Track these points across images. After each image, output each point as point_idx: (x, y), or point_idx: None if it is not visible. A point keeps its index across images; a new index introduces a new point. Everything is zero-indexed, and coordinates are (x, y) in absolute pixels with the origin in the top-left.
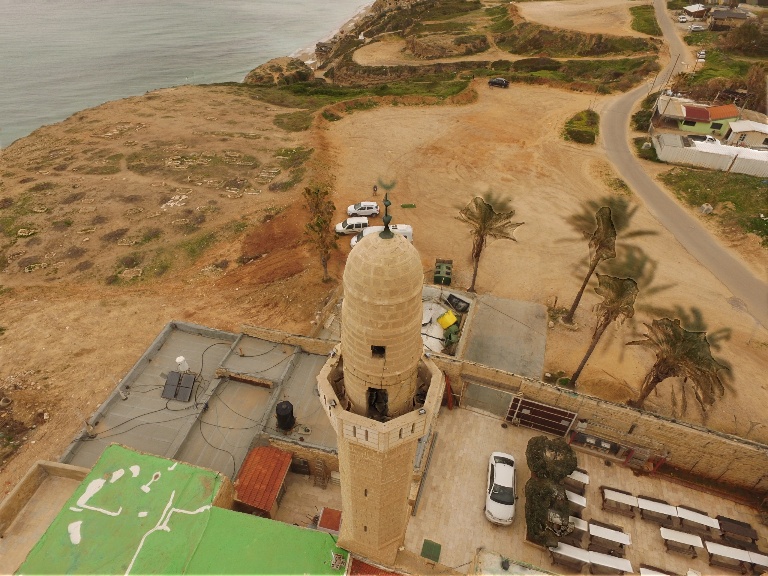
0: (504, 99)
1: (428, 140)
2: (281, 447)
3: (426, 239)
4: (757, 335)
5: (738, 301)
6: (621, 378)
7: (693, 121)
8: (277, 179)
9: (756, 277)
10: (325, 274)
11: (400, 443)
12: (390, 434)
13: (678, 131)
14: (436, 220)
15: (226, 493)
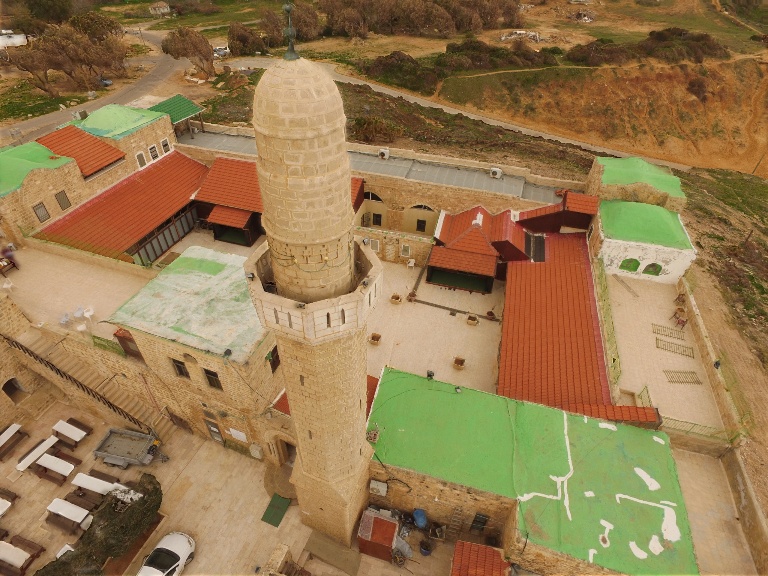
0: None
1: None
2: None
3: None
4: None
5: None
6: None
7: None
8: None
9: None
10: None
11: None
12: None
13: None
14: None
15: None
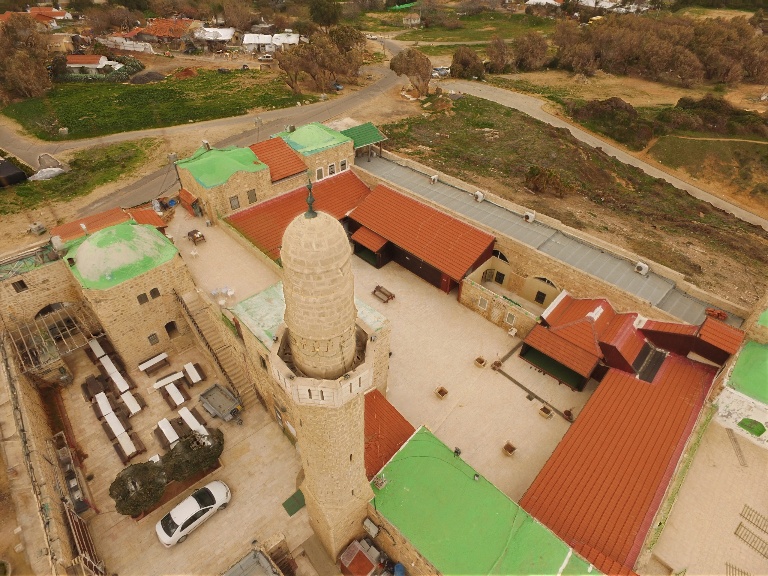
0: None
1: None
2: None
3: None
4: None
5: None
6: None
7: None
8: None
9: None
10: None
11: None
12: None
13: None
14: None
15: None
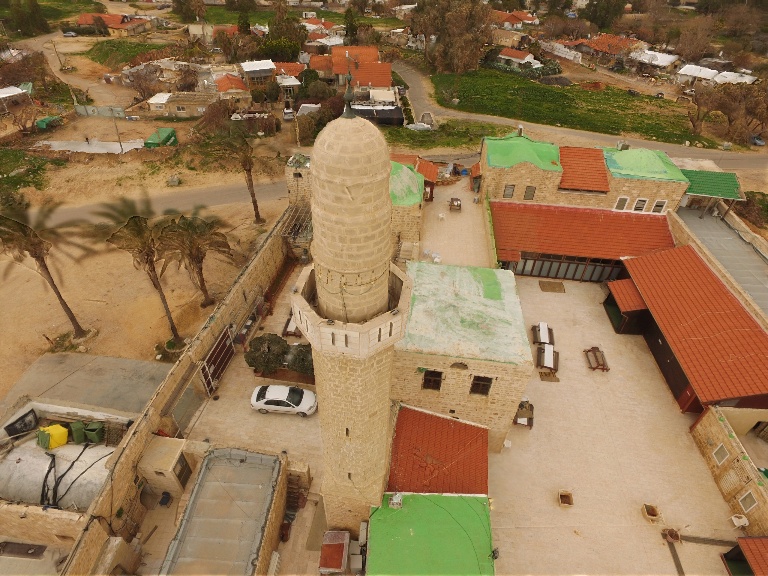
0: None
1: None
2: None
3: None
4: None
5: (102, 224)
6: (173, 308)
7: None
8: None
9: (78, 207)
10: None
11: None
12: None
13: None
14: None
15: None
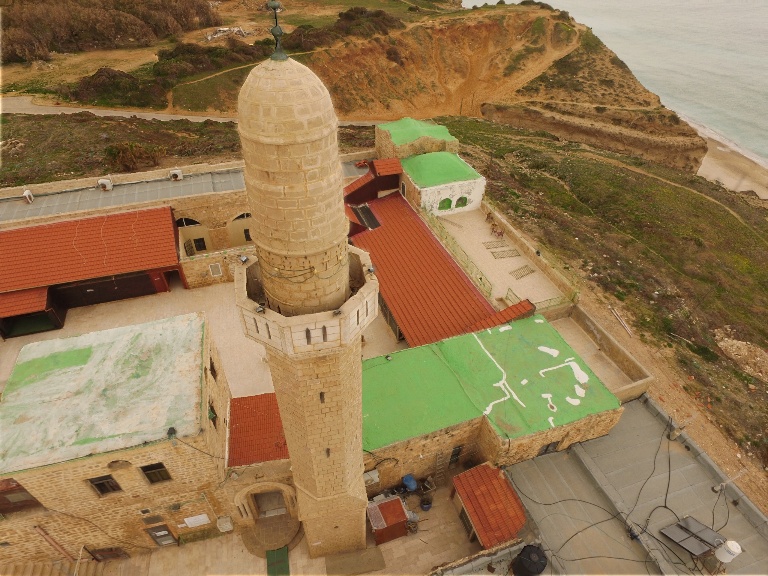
0: None
1: None
2: None
3: None
4: None
5: None
6: None
7: None
8: None
9: None
10: None
11: None
12: None
13: None
14: None
15: None
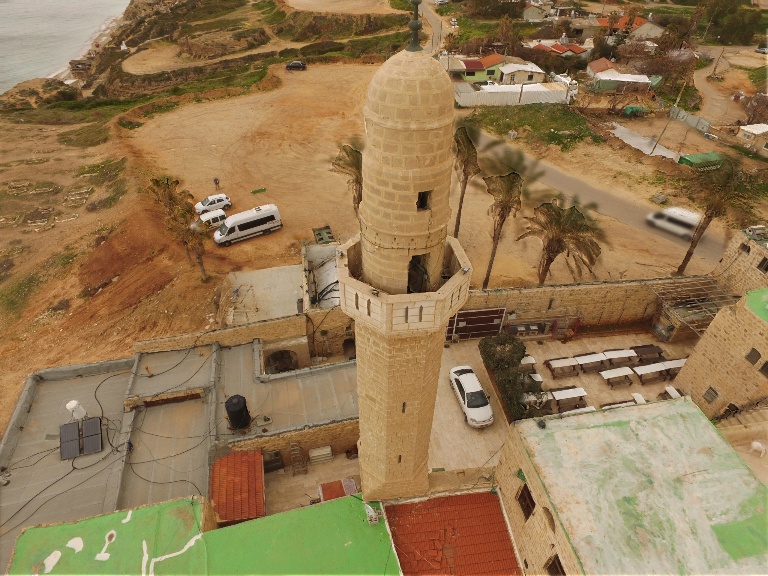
0: (307, 80)
1: (250, 128)
2: (245, 448)
3: (292, 216)
4: (589, 216)
5: (565, 196)
6: (516, 276)
7: (473, 71)
8: (93, 198)
9: (568, 176)
10: (203, 273)
11: (449, 315)
12: (445, 302)
13: (464, 82)
14: (293, 197)
15: (209, 516)
